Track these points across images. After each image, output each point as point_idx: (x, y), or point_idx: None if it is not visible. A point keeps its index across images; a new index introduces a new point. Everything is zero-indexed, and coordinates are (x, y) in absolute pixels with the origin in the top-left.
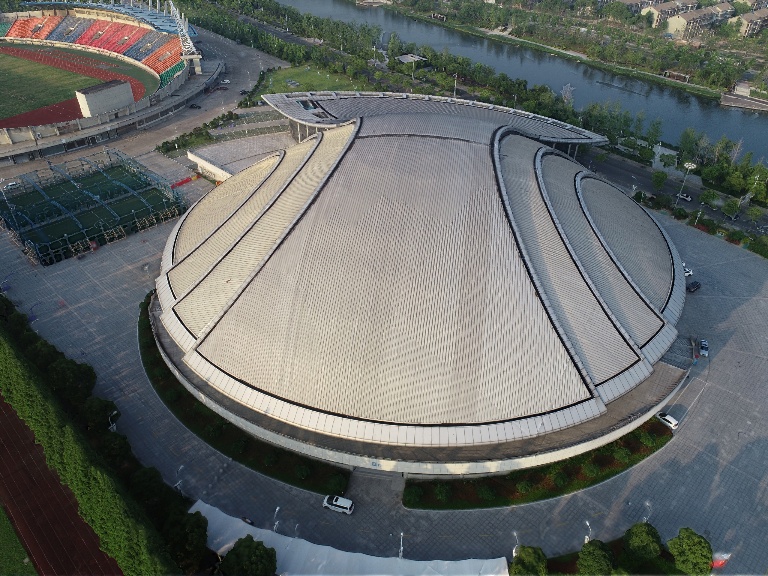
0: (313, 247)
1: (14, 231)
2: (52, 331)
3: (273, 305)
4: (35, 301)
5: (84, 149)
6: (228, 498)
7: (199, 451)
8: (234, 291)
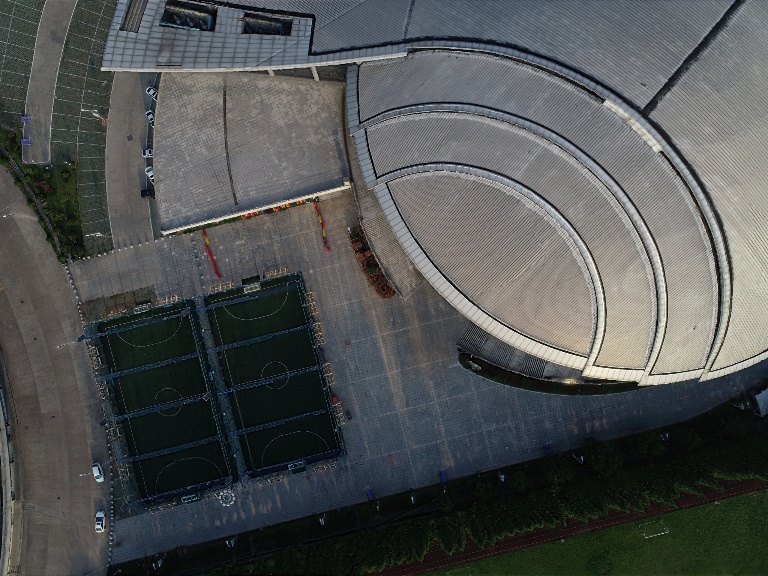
0: (764, 253)
1: (267, 480)
2: (475, 461)
3: (764, 308)
4: (412, 470)
5: (2, 361)
6: (746, 375)
7: (694, 380)
8: (709, 328)
